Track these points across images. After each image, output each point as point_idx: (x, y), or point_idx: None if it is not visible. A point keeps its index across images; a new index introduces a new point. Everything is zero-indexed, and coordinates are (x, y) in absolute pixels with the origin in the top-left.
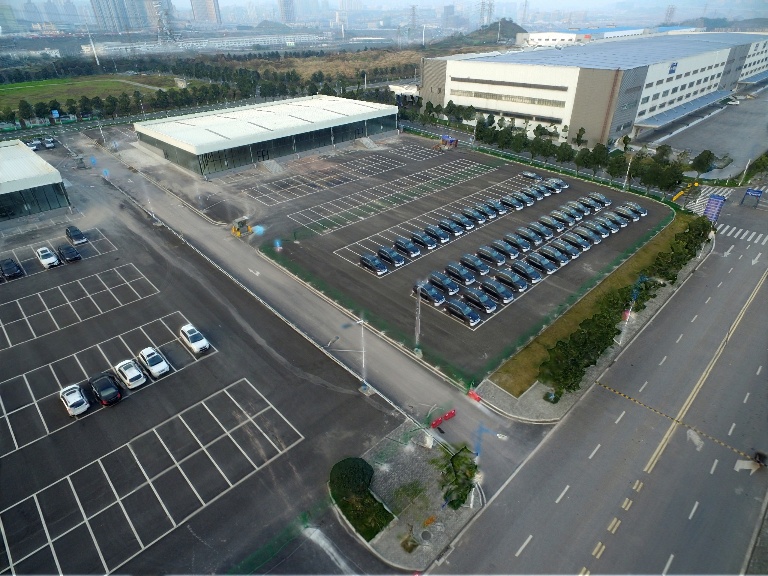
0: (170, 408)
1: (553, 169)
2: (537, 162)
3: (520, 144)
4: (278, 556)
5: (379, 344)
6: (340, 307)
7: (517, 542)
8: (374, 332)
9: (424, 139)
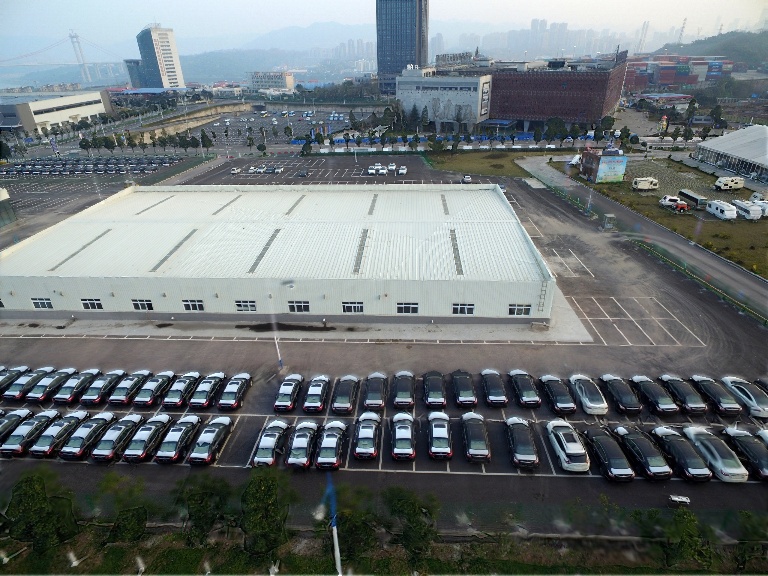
0: None
1: None
2: None
3: None
4: None
5: None
6: (189, 170)
7: None
8: None
9: None
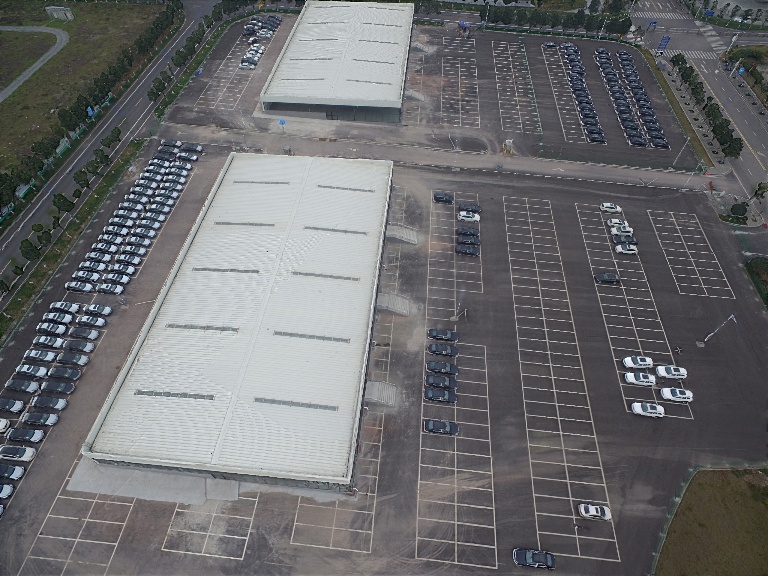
0: (650, 233)
1: (545, 33)
2: (528, 29)
3: (524, 19)
4: (741, 241)
5: (655, 173)
6: (619, 166)
7: (767, 204)
8: (646, 170)
9: (438, 28)
